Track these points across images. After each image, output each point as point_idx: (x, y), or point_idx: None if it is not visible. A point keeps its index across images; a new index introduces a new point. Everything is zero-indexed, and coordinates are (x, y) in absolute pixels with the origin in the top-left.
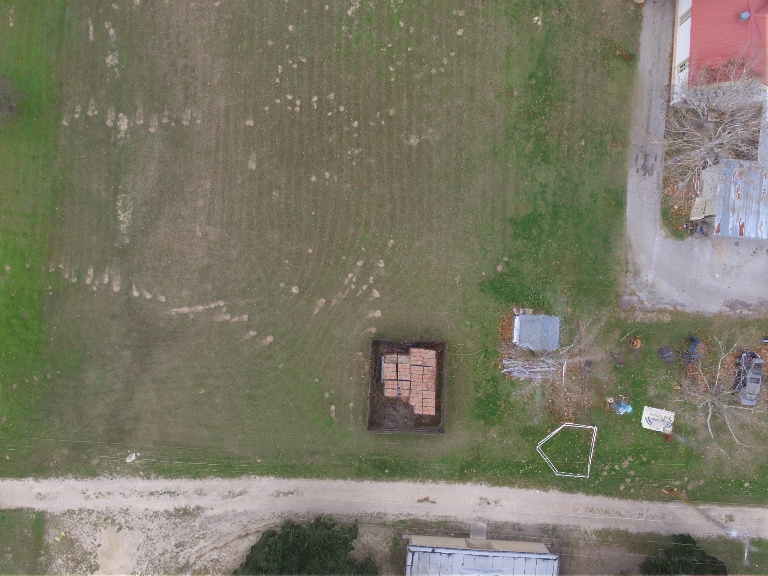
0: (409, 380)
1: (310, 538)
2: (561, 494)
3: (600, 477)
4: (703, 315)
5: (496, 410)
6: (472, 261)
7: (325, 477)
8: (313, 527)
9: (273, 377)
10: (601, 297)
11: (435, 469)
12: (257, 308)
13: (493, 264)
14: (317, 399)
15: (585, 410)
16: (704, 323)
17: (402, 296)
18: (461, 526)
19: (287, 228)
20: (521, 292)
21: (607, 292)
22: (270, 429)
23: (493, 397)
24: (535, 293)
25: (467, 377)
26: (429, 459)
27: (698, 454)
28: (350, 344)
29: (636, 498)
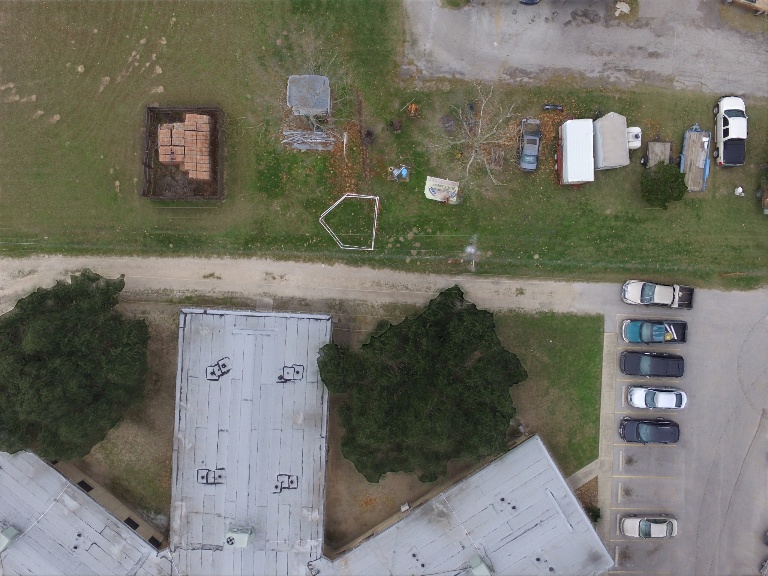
0: (183, 145)
1: (73, 290)
2: (347, 268)
3: (385, 250)
4: (483, 83)
5: (278, 182)
6: (252, 36)
7: (112, 254)
8: (78, 281)
9: (60, 155)
10: (379, 67)
11: (219, 243)
12: (45, 88)
13: (273, 38)
14: (102, 175)
15: (367, 180)
16: (484, 91)
17: (184, 72)
18: (247, 302)
19: (73, 10)
20: (301, 65)
21: (385, 62)
22: (57, 206)
23: (275, 170)
24: (315, 66)
25: (249, 150)
26: (213, 233)
27: (484, 225)
28: (134, 120)
29: (423, 271)
